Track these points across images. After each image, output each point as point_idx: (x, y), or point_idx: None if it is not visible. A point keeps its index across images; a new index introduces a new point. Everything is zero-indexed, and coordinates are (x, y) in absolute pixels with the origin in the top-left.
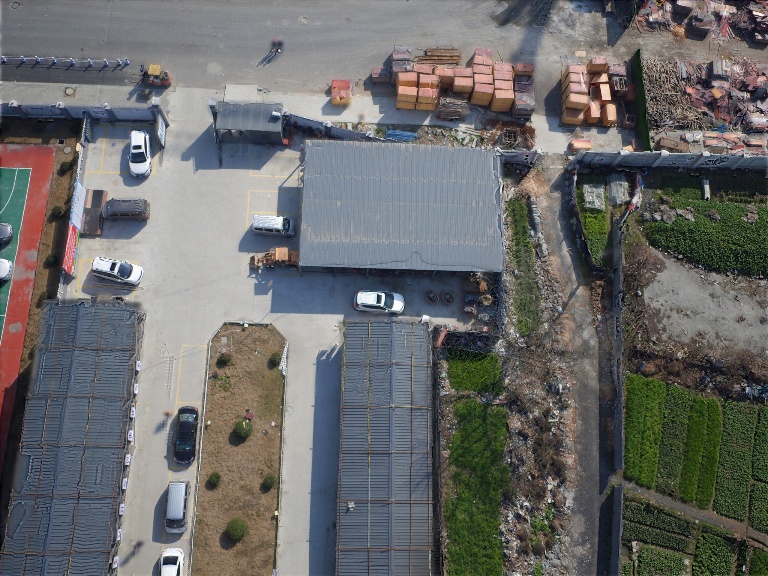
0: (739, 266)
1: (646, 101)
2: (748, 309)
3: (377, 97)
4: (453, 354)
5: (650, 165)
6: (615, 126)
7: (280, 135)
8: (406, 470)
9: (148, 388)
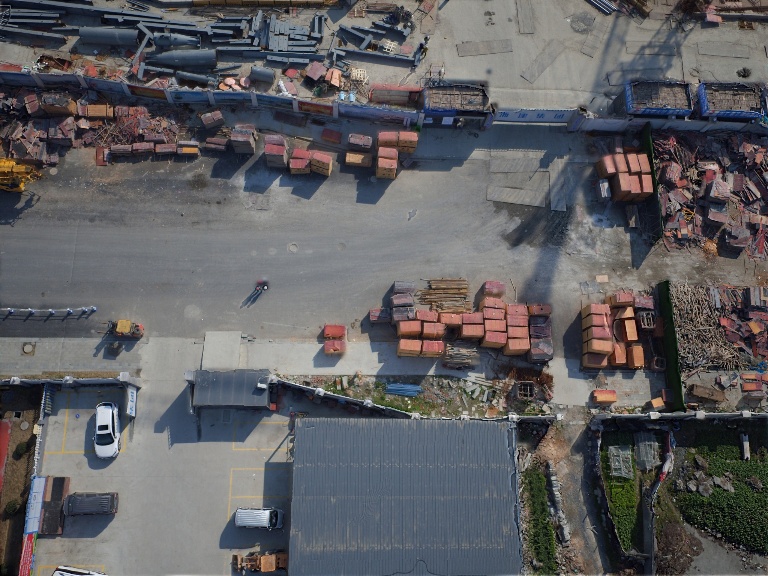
0: None
1: (677, 345)
2: None
3: (376, 342)
4: None
5: (682, 418)
6: (642, 368)
7: (266, 407)
8: None
9: None
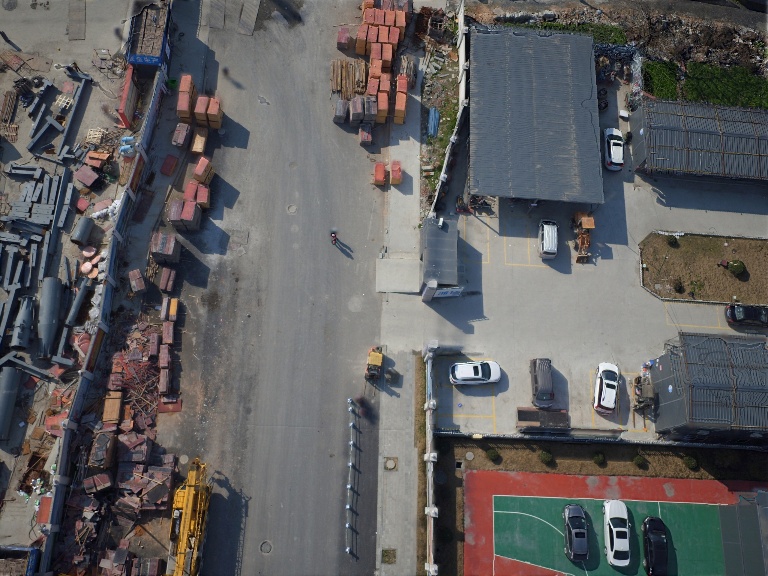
0: None
1: None
2: None
3: (390, 141)
4: None
5: None
6: None
7: None
8: (767, 128)
9: None
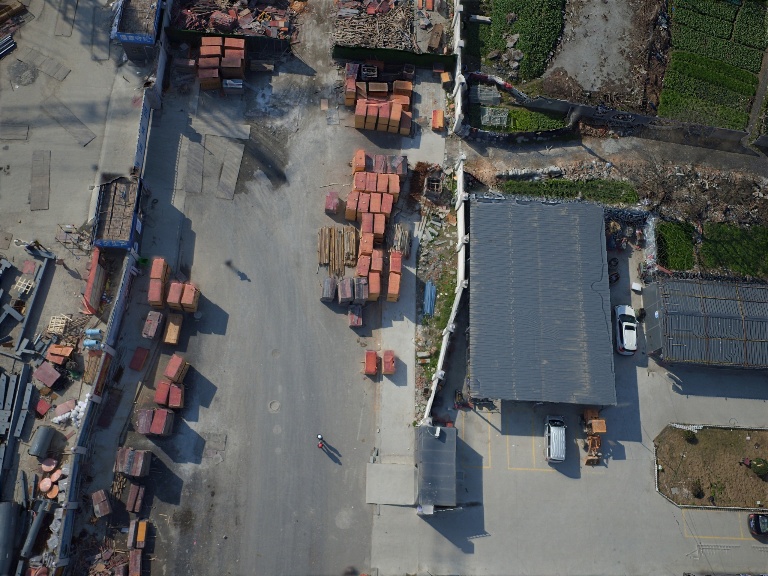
0: (559, 8)
1: None
2: (595, 10)
3: (382, 323)
4: (662, 264)
5: None
6: None
7: None
8: None
9: (733, 571)
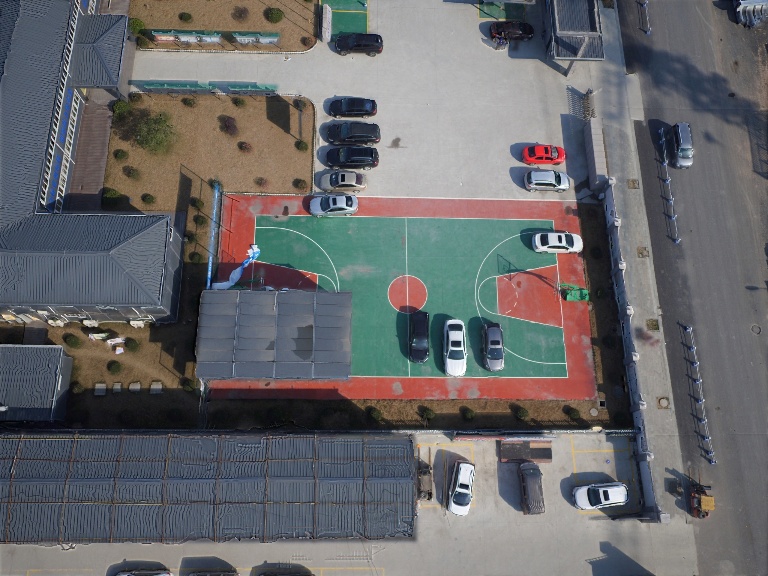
0: None
1: None
2: None
3: None
4: None
5: None
6: None
7: None
8: None
9: None
